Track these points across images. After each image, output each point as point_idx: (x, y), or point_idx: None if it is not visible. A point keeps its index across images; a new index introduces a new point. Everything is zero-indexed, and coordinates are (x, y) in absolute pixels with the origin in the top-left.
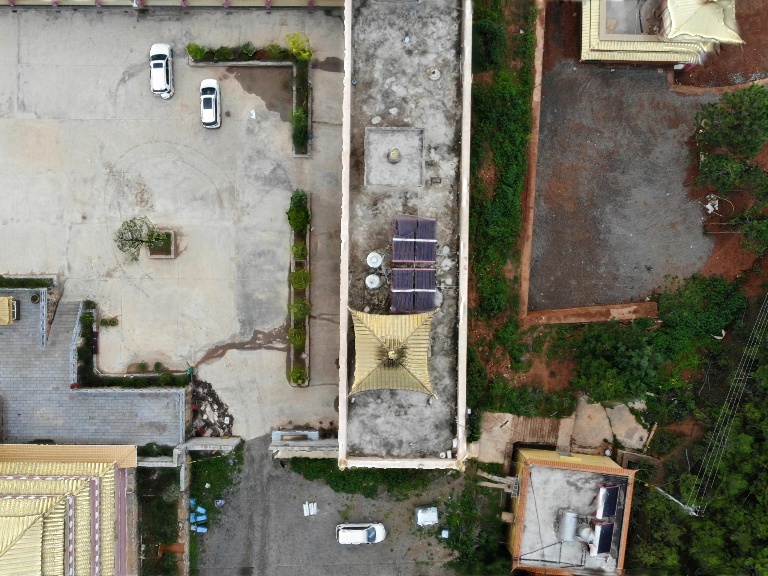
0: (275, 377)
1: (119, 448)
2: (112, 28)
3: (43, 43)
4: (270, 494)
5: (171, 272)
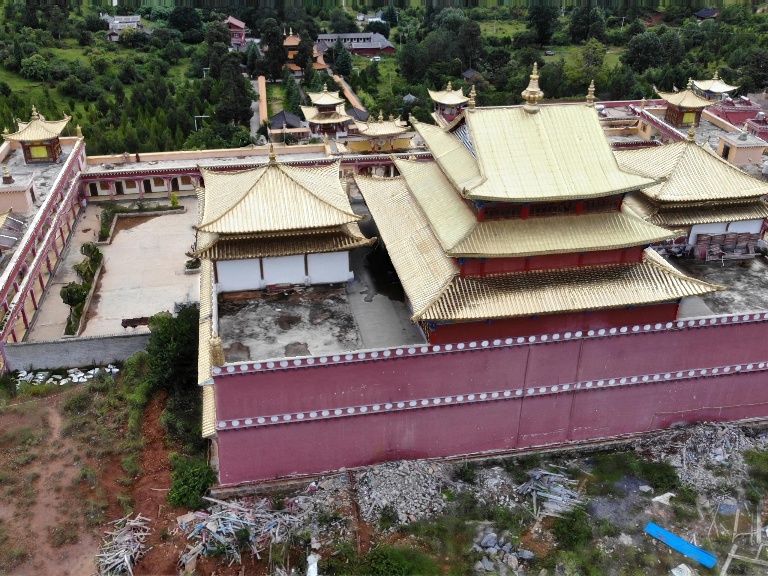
0: None
1: None
2: None
3: None
4: None
5: None
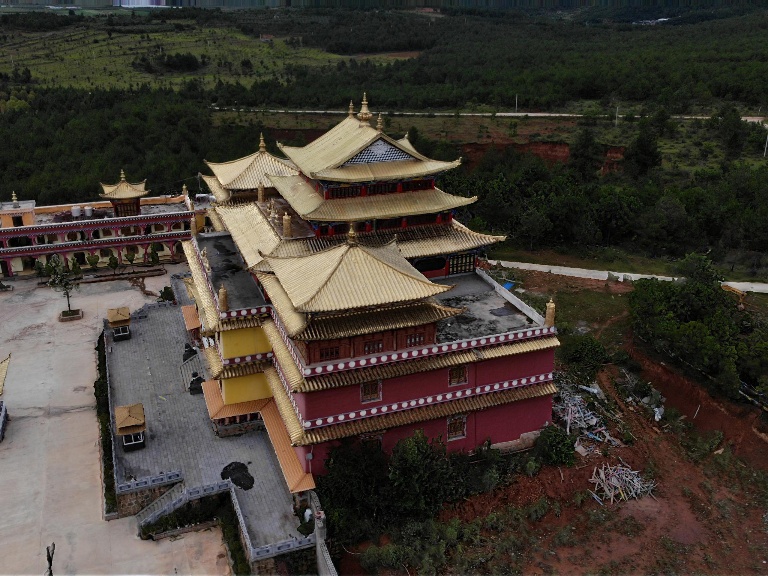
0: None
1: None
2: None
3: None
4: None
5: None
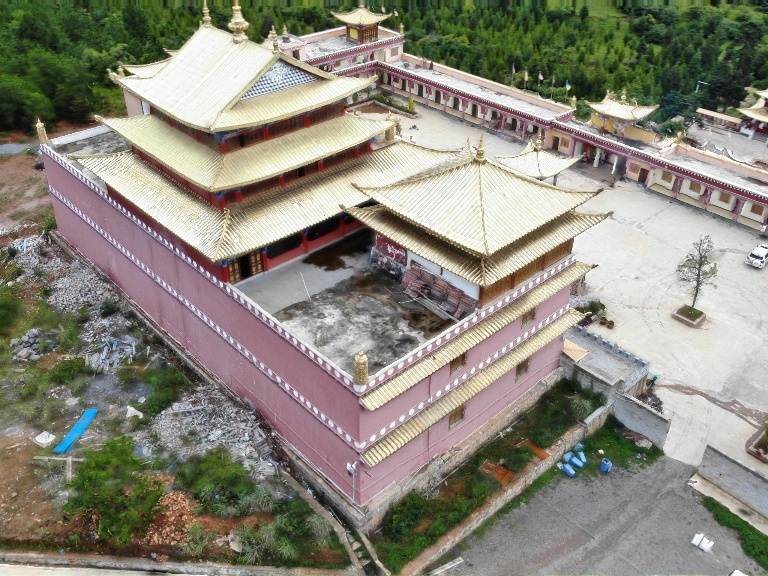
0: (733, 437)
1: (573, 344)
2: (734, 233)
3: (679, 217)
4: (662, 502)
5: (683, 332)
